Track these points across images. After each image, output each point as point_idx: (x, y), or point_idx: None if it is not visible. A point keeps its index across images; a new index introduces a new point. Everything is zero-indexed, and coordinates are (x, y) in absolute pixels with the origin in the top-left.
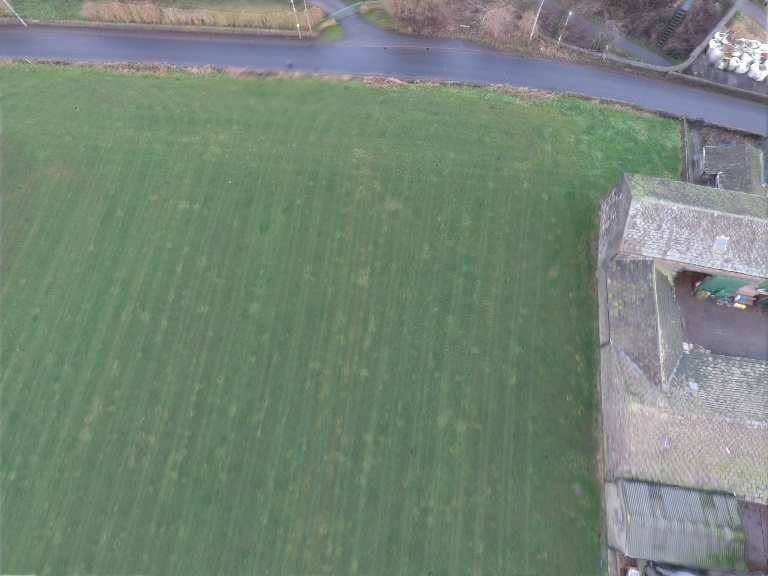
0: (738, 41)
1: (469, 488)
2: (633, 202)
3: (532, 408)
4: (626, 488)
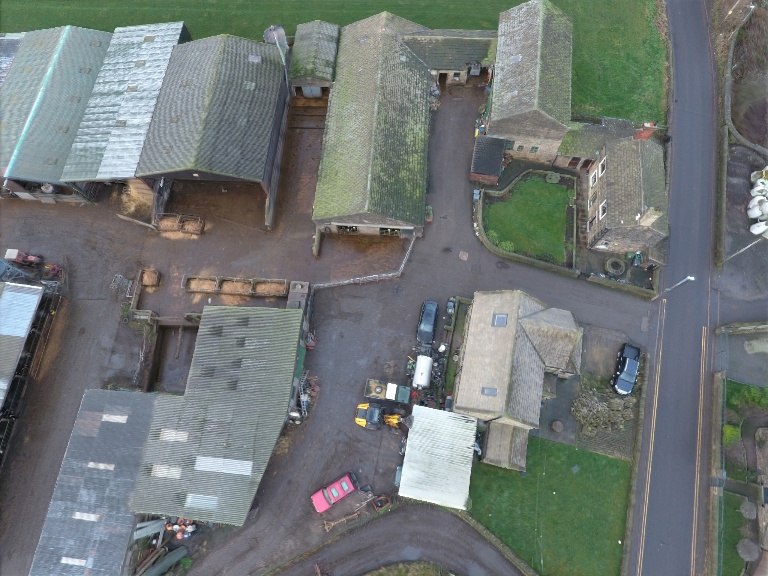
0: None
1: None
2: None
3: None
4: (335, 25)
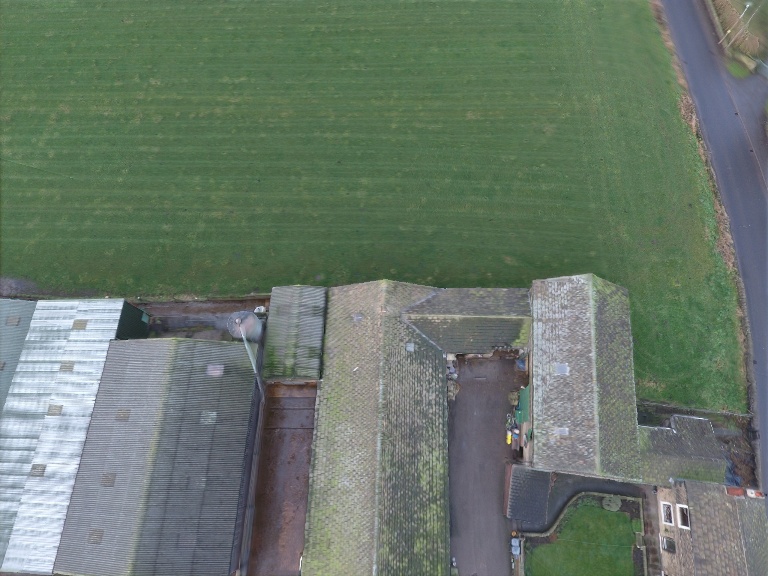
0: None
1: (316, 202)
2: (585, 275)
3: (381, 243)
4: (320, 289)
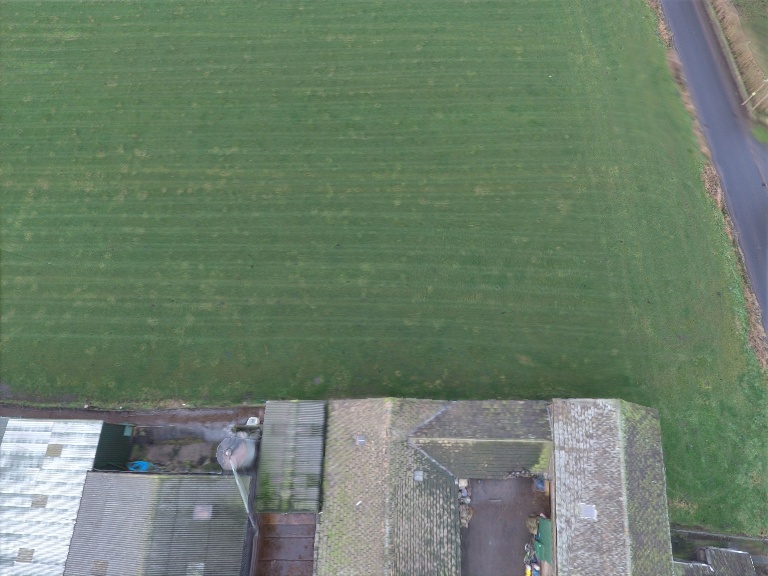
0: None
1: (314, 291)
2: (612, 401)
3: (384, 340)
4: (319, 403)
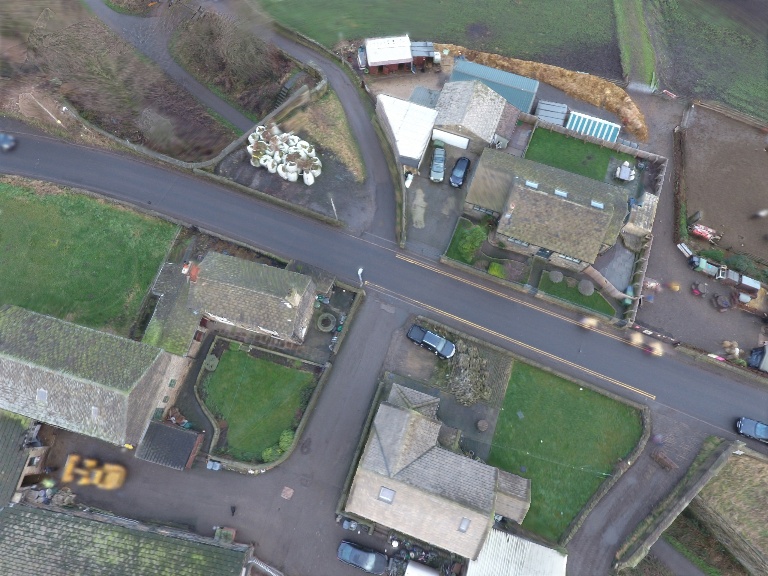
0: (274, 137)
1: None
2: None
3: None
4: None
